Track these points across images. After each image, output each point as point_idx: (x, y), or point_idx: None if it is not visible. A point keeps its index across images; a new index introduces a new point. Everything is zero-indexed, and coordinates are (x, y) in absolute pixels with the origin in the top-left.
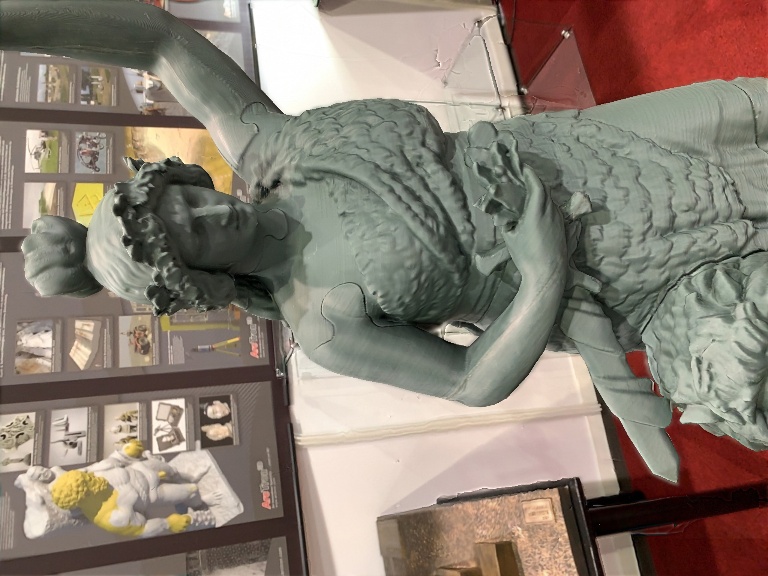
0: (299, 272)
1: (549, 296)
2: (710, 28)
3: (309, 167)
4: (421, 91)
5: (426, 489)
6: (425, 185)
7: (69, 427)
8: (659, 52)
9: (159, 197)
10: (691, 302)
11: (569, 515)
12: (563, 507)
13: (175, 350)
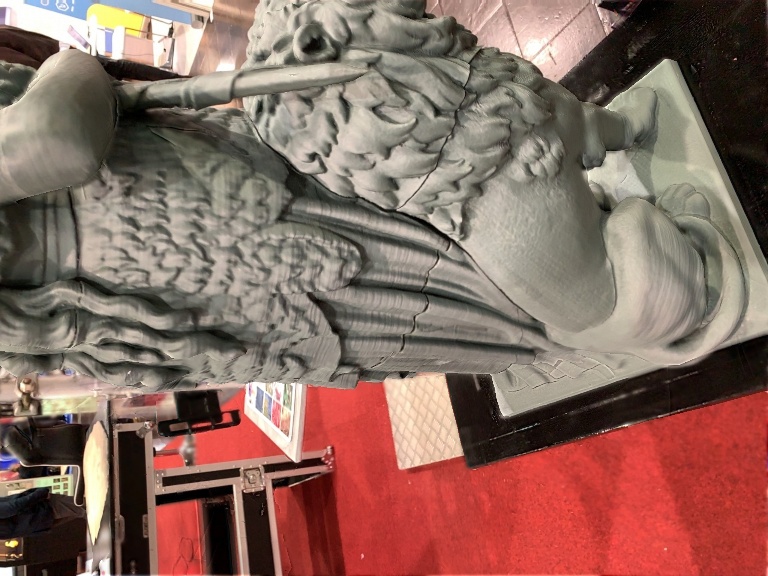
0: None
1: None
2: (508, 568)
3: None
4: None
5: None
6: None
7: None
8: None
9: None
10: None
11: None
12: None
13: None
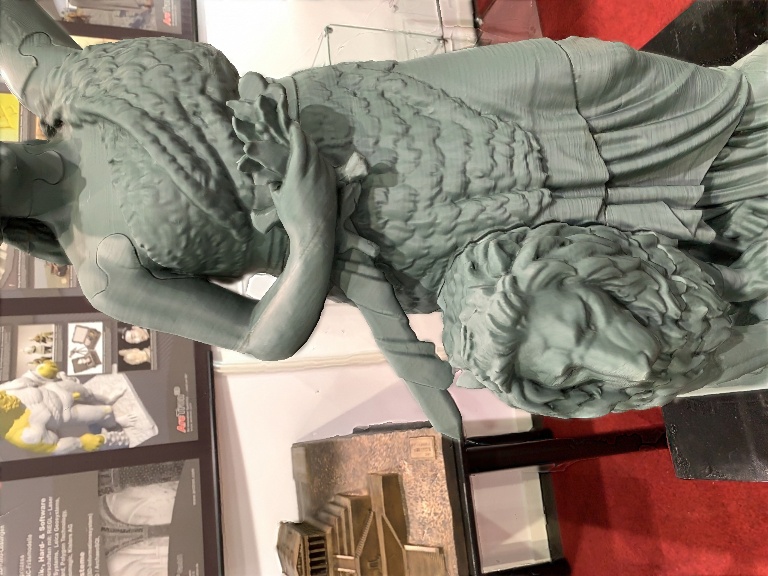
0: (76, 219)
1: (312, 259)
2: None
3: (80, 109)
4: (368, 14)
5: (344, 419)
6: (200, 136)
7: None
8: None
9: None
10: (464, 271)
11: (449, 453)
12: (443, 445)
13: None
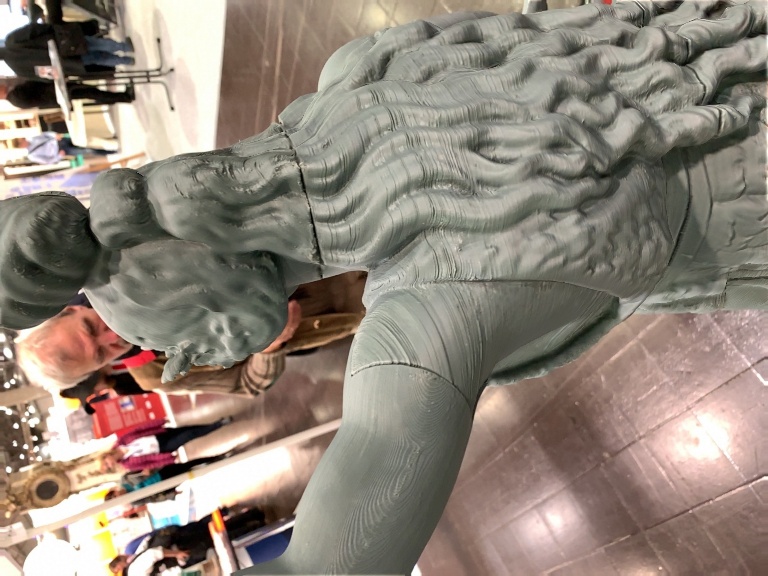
0: None
1: None
2: None
3: None
4: None
5: None
6: None
7: None
8: None
9: None
10: None
11: None
12: None
13: None
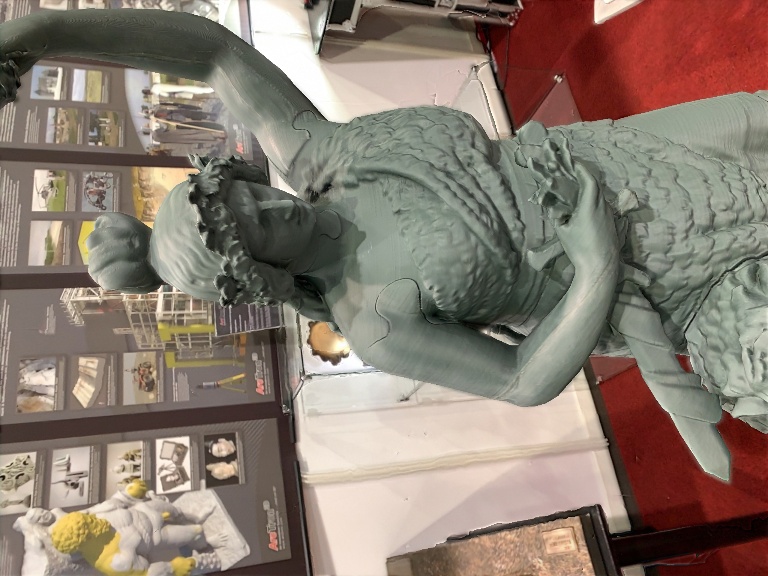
0: (352, 271)
1: (604, 287)
2: (700, 69)
3: (363, 168)
4: None
5: (435, 528)
6: (477, 184)
7: (71, 467)
8: (651, 93)
9: (228, 189)
10: (738, 294)
11: (592, 544)
12: (586, 536)
13: (180, 387)
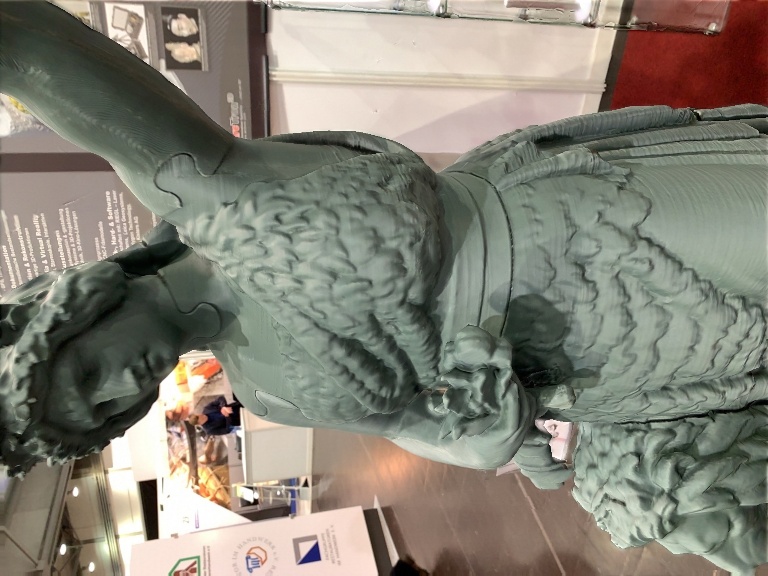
0: (233, 356)
1: None
2: None
3: None
4: None
5: (398, 141)
6: (391, 347)
7: None
8: None
9: (46, 398)
10: (628, 466)
11: None
12: None
13: None
